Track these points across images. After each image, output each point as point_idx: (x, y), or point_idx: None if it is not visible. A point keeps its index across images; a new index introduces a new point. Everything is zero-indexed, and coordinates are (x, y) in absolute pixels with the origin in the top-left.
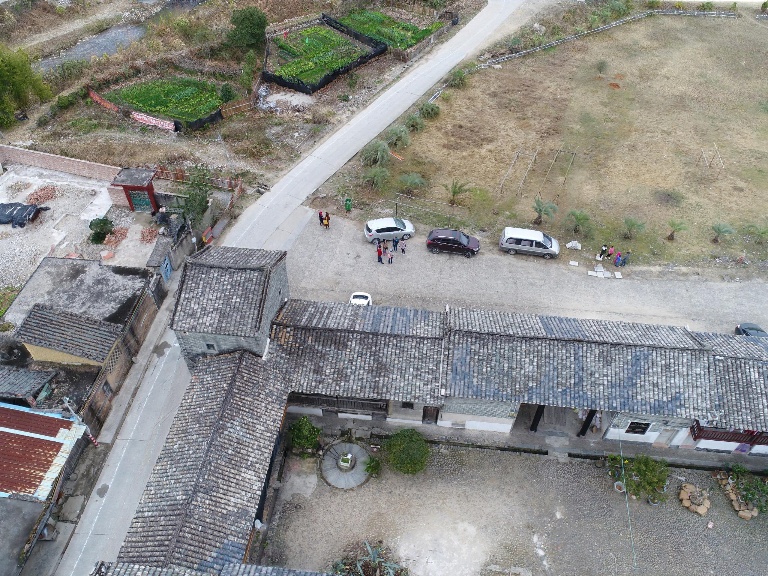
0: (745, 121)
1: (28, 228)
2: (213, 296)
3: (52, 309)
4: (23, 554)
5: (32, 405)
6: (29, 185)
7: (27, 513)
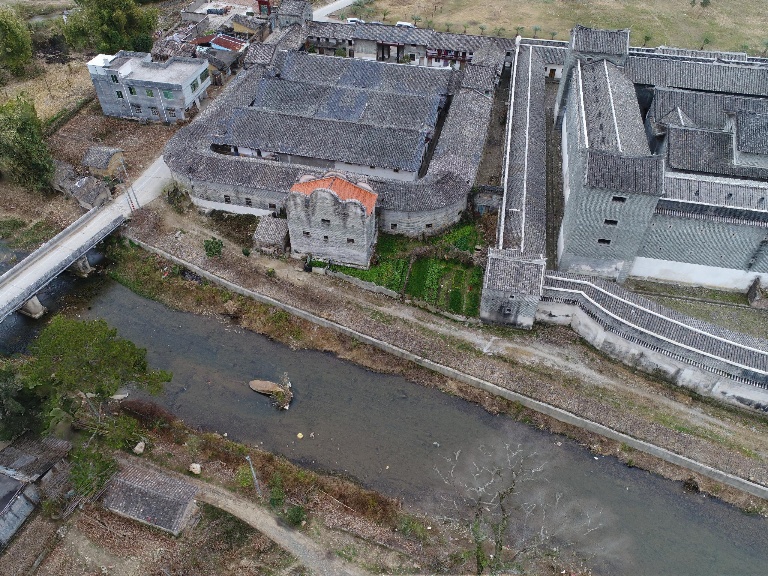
0: (531, 4)
1: (223, 15)
2: (290, 7)
3: (241, 17)
4: (236, 57)
5: (235, 37)
6: (221, 5)
7: (236, 53)
